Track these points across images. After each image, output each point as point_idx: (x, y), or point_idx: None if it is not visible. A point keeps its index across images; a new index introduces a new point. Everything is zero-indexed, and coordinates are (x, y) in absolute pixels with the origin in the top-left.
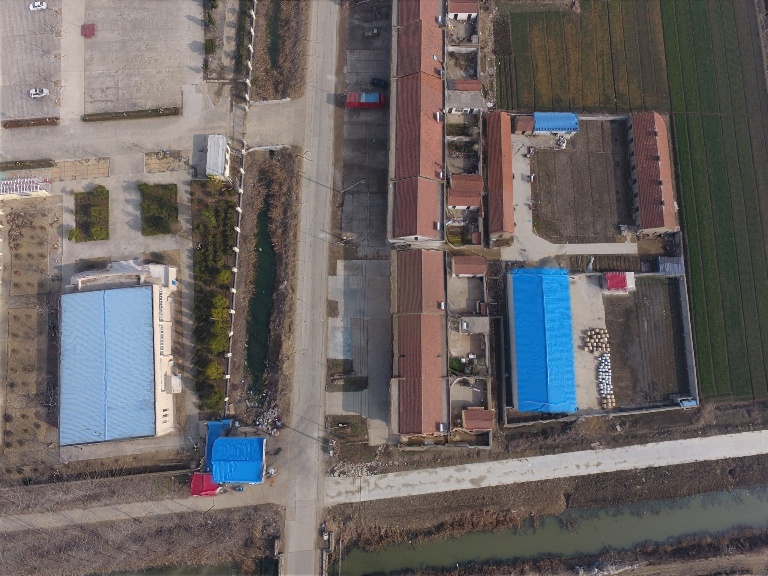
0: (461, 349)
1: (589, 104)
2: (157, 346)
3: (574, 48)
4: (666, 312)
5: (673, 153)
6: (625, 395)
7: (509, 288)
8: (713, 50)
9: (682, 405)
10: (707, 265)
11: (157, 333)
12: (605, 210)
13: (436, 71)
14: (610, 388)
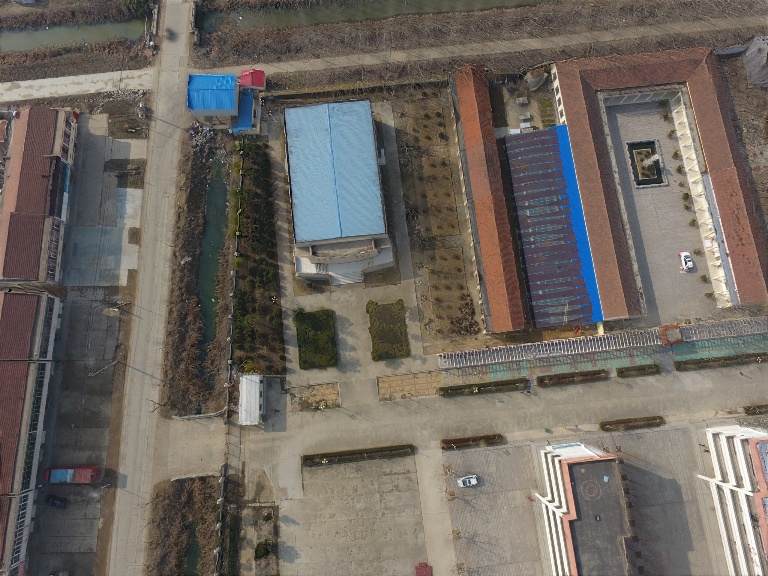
0: None
1: None
2: None
3: None
4: None
5: None
6: None
7: None
8: None
9: None
10: None
11: None
12: None
13: None
14: None
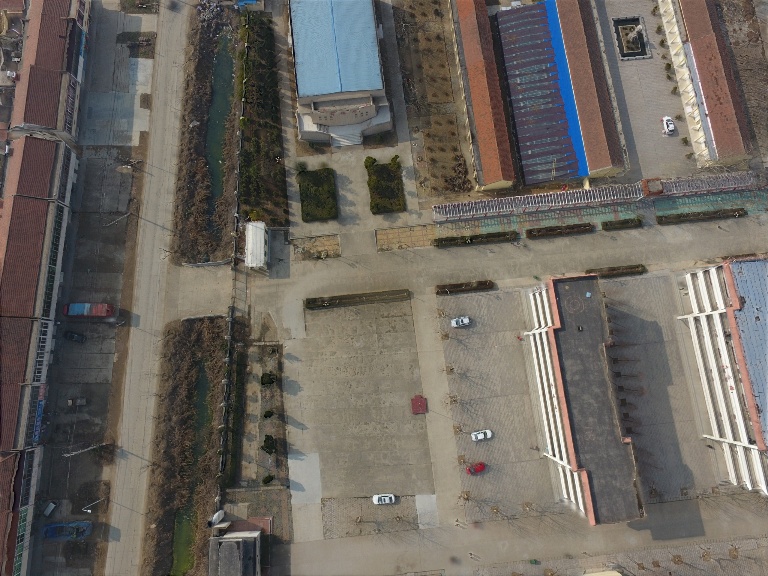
0: None
1: None
2: None
3: None
4: None
5: None
6: None
7: None
8: None
9: None
10: None
11: None
12: None
13: None
14: None
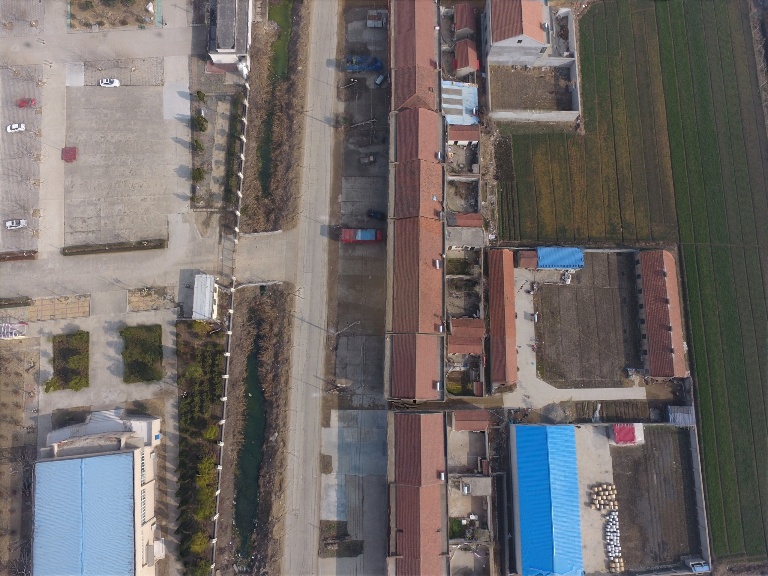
0: (462, 508)
1: (594, 234)
2: (138, 518)
3: (579, 173)
4: (676, 464)
5: (682, 288)
6: (634, 557)
7: (512, 439)
8: (722, 175)
9: (694, 570)
10: (718, 411)
11: (138, 504)
12: (612, 351)
13: (435, 213)
14: (618, 550)
